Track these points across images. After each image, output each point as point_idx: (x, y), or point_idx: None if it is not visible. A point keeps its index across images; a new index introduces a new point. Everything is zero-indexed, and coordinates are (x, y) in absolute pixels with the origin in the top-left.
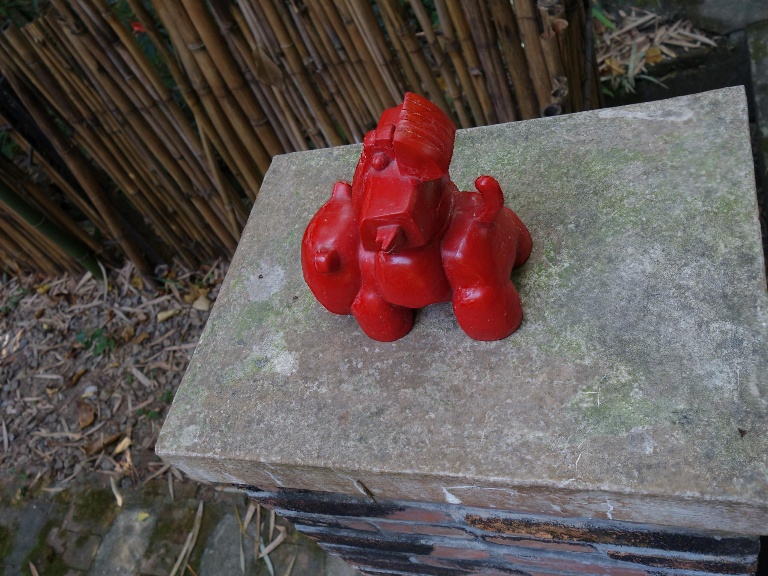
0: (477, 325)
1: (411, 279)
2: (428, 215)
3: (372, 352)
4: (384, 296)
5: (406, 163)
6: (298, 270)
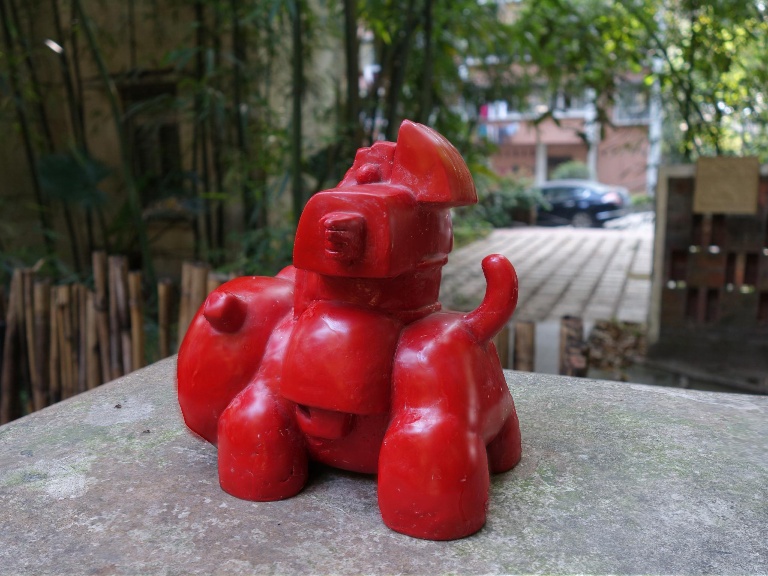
0: (410, 485)
1: (339, 350)
2: (407, 245)
3: (214, 505)
4: (283, 385)
5: (406, 163)
6: (173, 412)
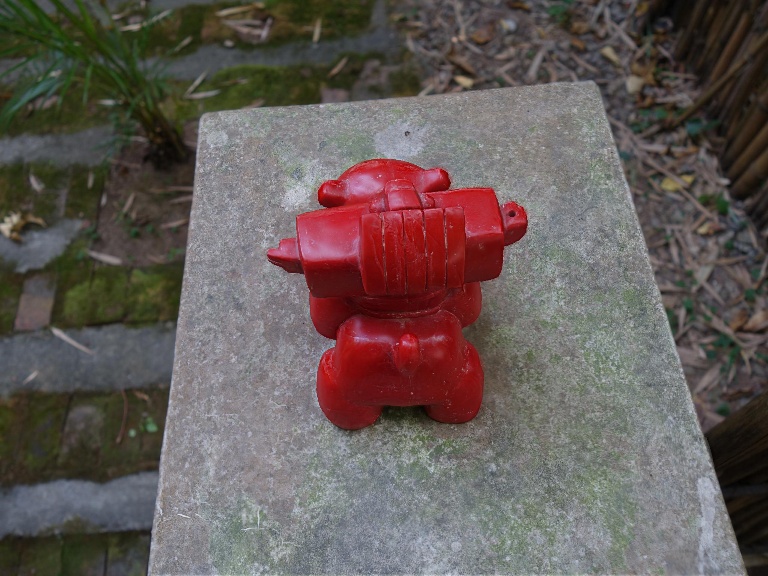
0: None
1: None
2: (338, 289)
3: None
4: None
5: None
6: None
